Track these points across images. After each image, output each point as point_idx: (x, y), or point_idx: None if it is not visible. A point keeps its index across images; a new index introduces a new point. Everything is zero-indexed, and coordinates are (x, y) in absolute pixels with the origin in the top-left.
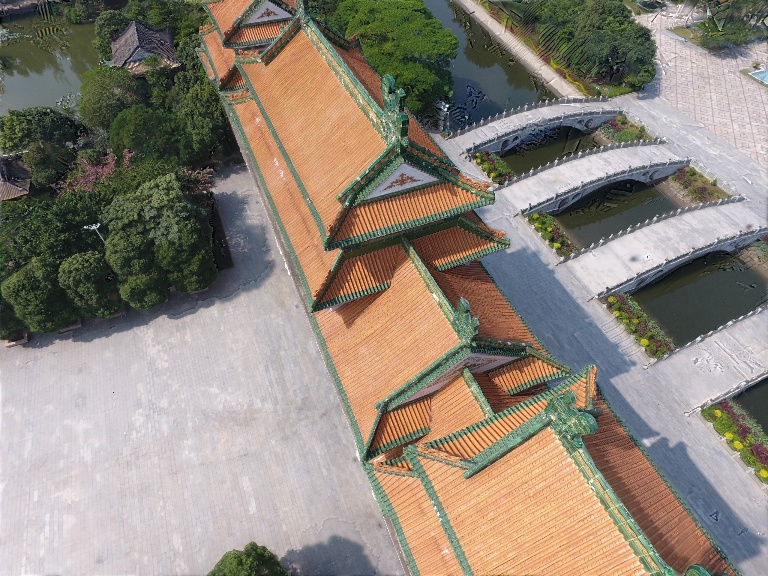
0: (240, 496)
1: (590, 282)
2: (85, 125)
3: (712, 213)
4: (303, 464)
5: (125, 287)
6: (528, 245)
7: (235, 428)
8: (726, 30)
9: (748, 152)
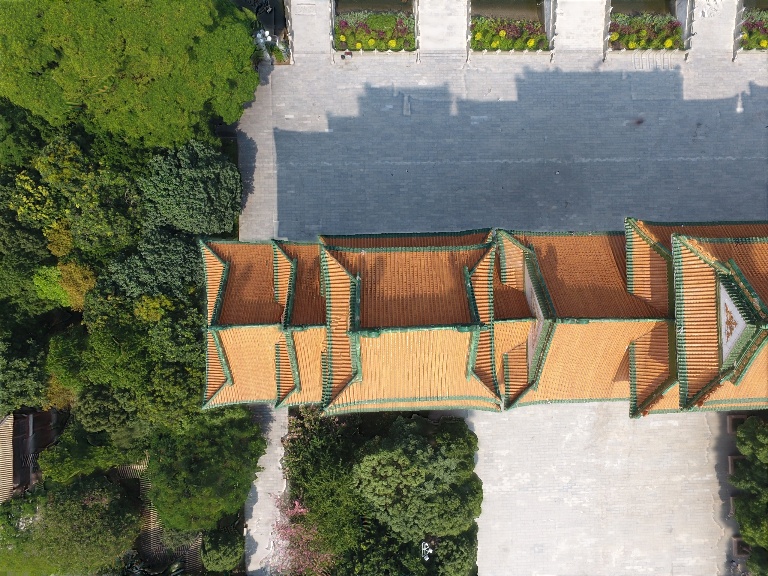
0: (663, 430)
1: (587, 42)
2: (120, 563)
3: None
4: None
5: (477, 514)
6: (515, 72)
7: (609, 425)
8: None
9: None
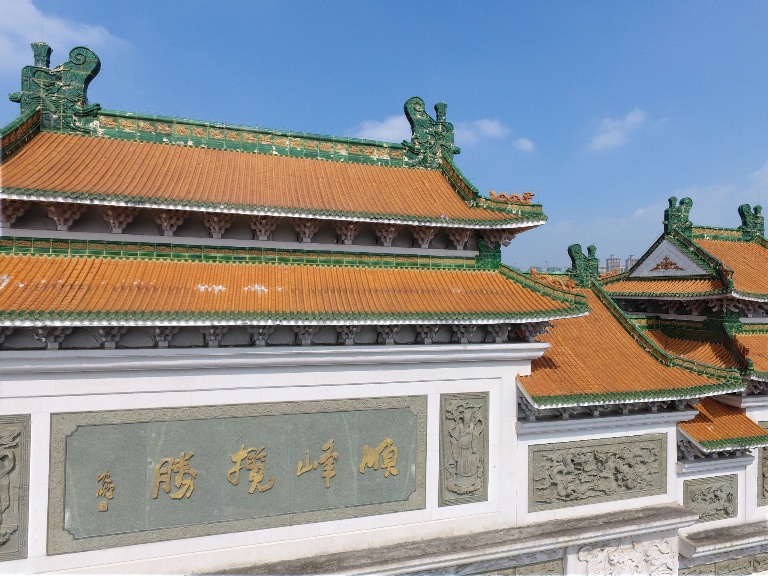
0: None
1: None
2: None
3: None
4: None
5: None
6: None
7: None
8: None
9: None
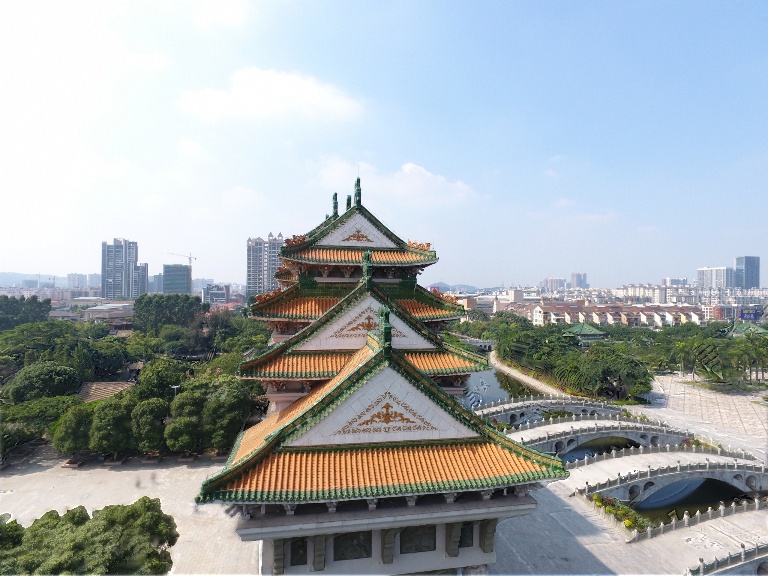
0: None
1: (574, 486)
2: None
3: (711, 457)
4: (236, 554)
5: (171, 424)
6: None
7: (193, 525)
8: (727, 378)
9: (760, 437)
